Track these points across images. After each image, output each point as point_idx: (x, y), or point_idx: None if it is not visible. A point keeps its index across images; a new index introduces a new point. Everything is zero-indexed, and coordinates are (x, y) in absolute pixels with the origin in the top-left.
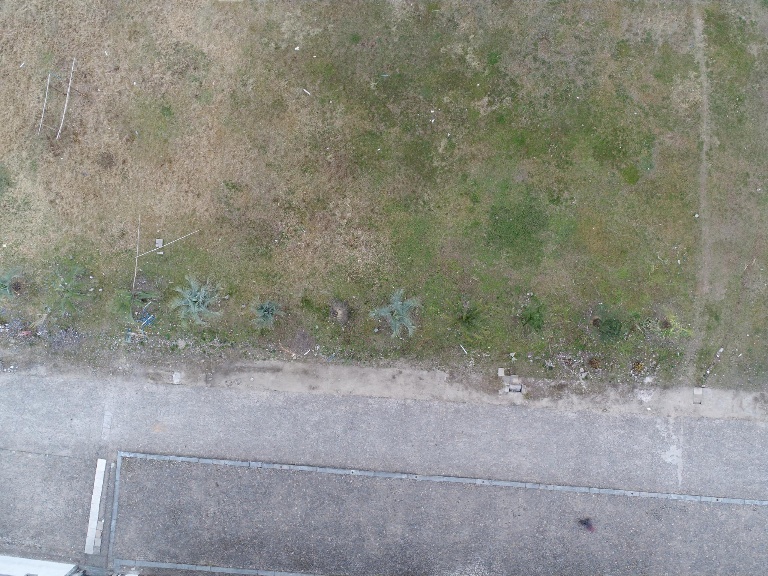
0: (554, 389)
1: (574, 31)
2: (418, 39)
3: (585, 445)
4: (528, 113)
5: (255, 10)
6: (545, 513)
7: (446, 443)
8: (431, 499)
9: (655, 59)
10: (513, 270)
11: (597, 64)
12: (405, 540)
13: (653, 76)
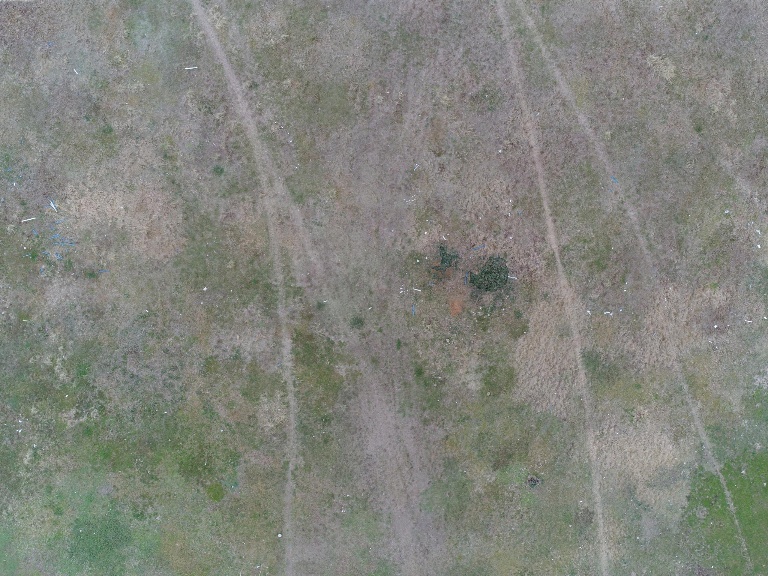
0: None
1: (164, 345)
2: (9, 348)
3: None
4: (115, 426)
5: None
6: None
7: None
8: None
9: (243, 377)
10: None
11: (186, 379)
12: None
13: (240, 394)
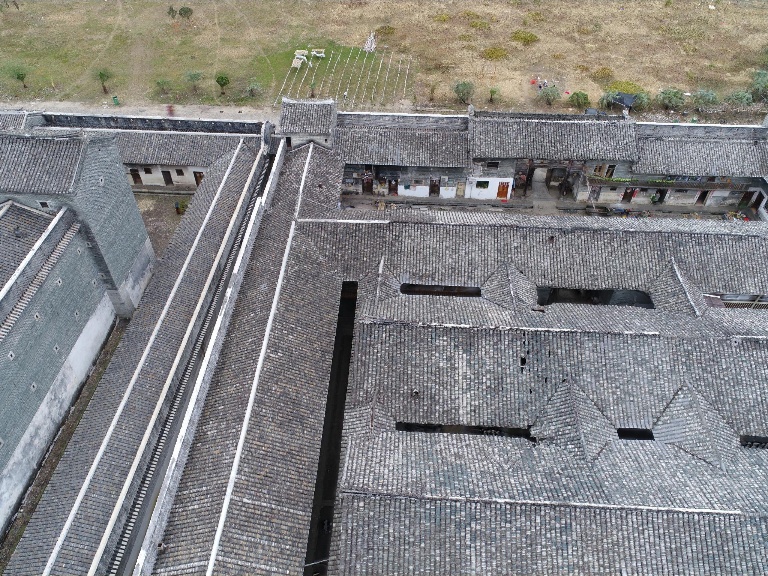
0: None
1: None
2: None
3: None
4: None
5: None
6: None
7: None
8: None
9: None
10: (1, 78)
11: None
12: None
13: None
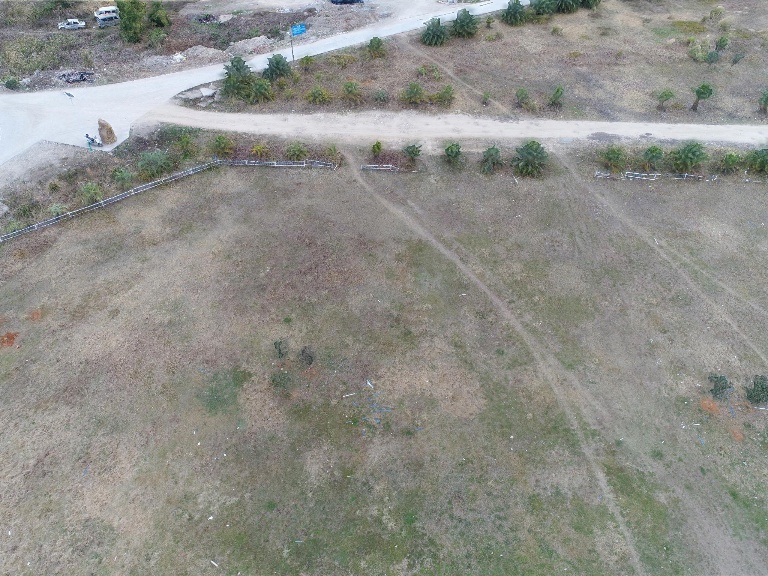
0: None
1: (485, 489)
2: (334, 503)
3: None
4: (452, 575)
5: (175, 483)
6: None
7: None
8: None
9: (570, 511)
10: None
11: (514, 519)
12: None
13: (572, 528)
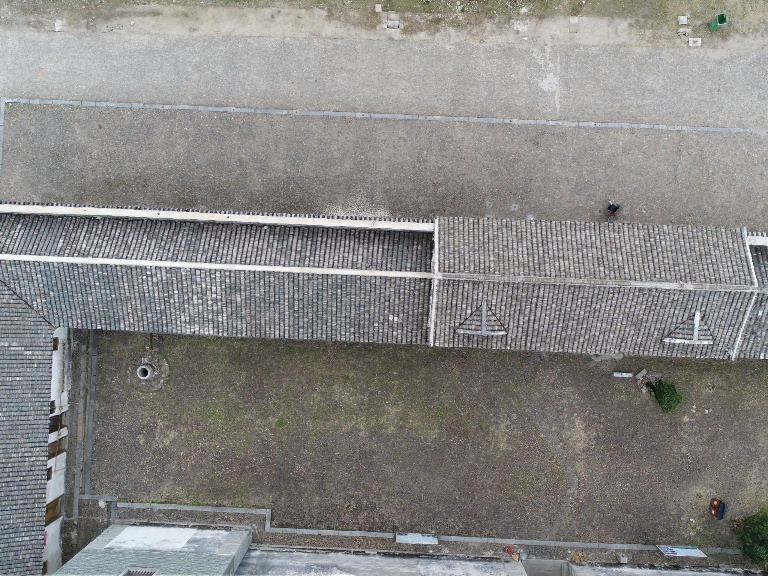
0: (431, 23)
1: None
2: None
3: (463, 76)
4: None
5: None
6: (425, 143)
7: (326, 79)
8: (312, 134)
9: None
10: None
11: None
12: (287, 175)
13: None
